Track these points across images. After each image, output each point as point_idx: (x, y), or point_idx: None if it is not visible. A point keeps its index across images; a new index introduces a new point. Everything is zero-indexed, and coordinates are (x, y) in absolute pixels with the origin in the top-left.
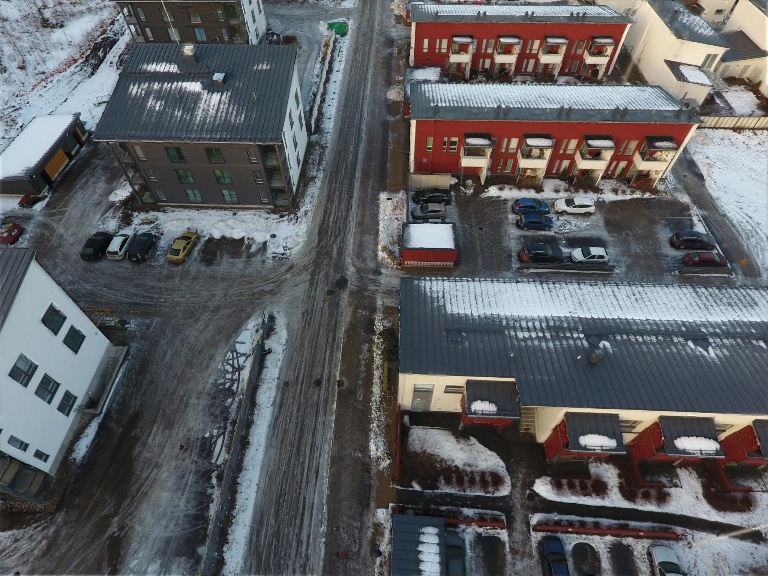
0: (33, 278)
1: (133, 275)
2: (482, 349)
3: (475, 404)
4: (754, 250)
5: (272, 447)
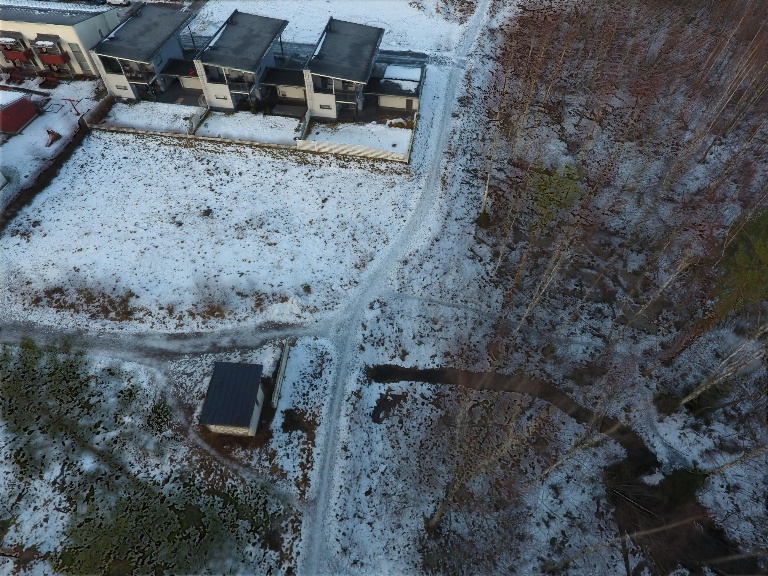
0: None
1: None
2: None
3: None
4: (192, 23)
5: None
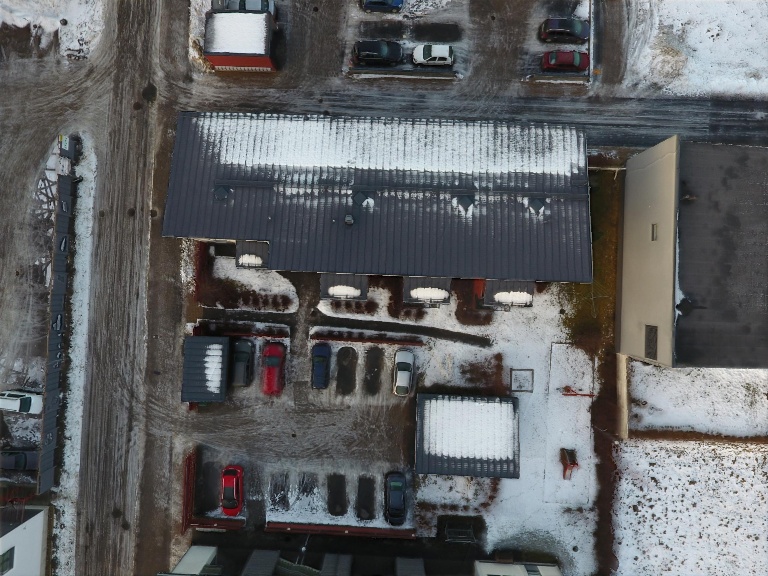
0: None
1: None
2: (246, 209)
3: (242, 258)
4: (633, 44)
5: (96, 273)
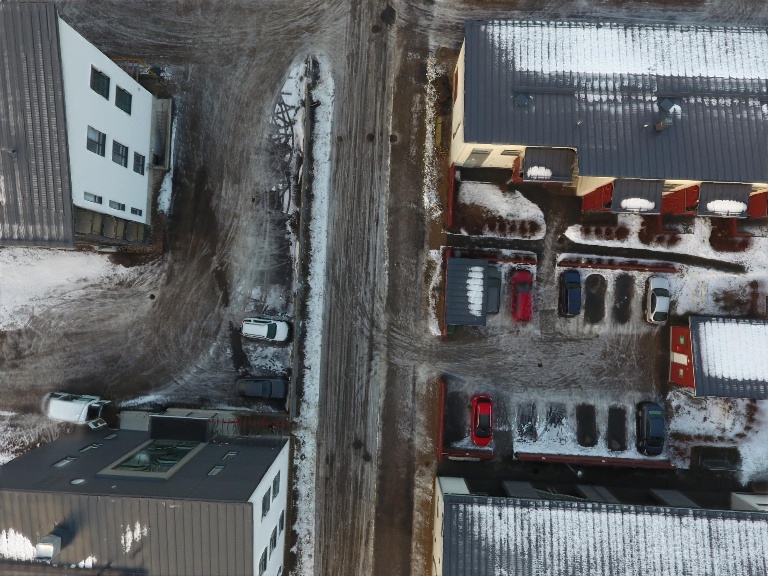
0: (66, 40)
1: (146, 6)
2: (548, 115)
3: (532, 170)
4: None
5: (335, 199)
